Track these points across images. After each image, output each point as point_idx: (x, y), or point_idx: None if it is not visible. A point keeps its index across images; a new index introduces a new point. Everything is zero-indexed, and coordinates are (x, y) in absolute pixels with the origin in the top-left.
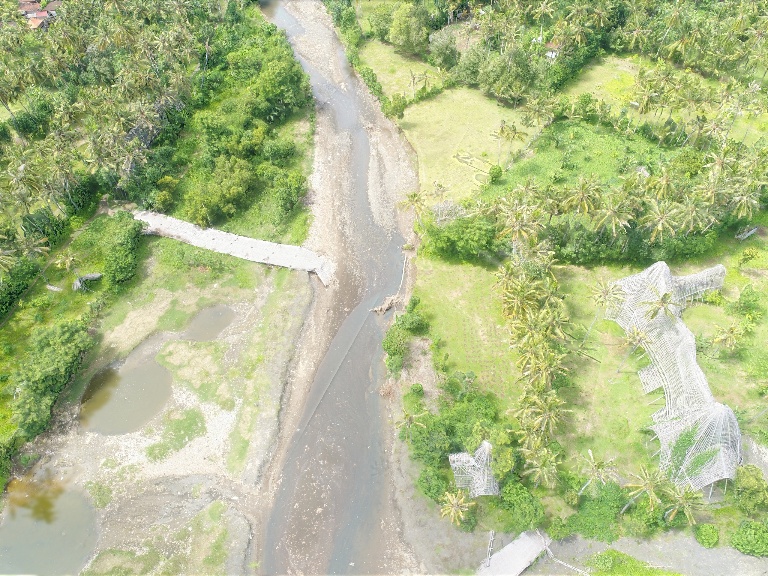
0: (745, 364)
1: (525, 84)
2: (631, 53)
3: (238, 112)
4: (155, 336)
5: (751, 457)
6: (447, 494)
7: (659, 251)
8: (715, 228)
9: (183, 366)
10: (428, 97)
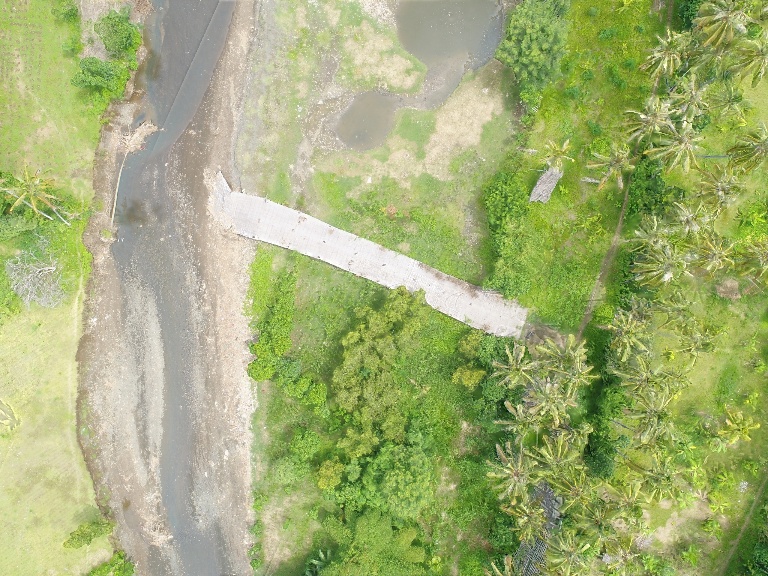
0: None
1: None
2: None
3: (374, 551)
4: (436, 105)
5: None
6: None
7: None
8: None
9: (388, 52)
10: None
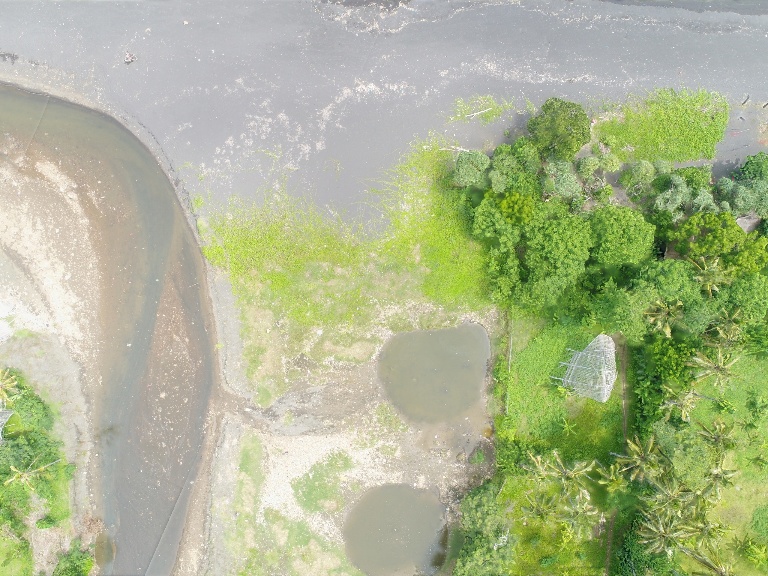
0: None
1: None
2: None
3: None
4: None
5: None
6: (7, 398)
7: None
8: None
9: (336, 570)
10: None
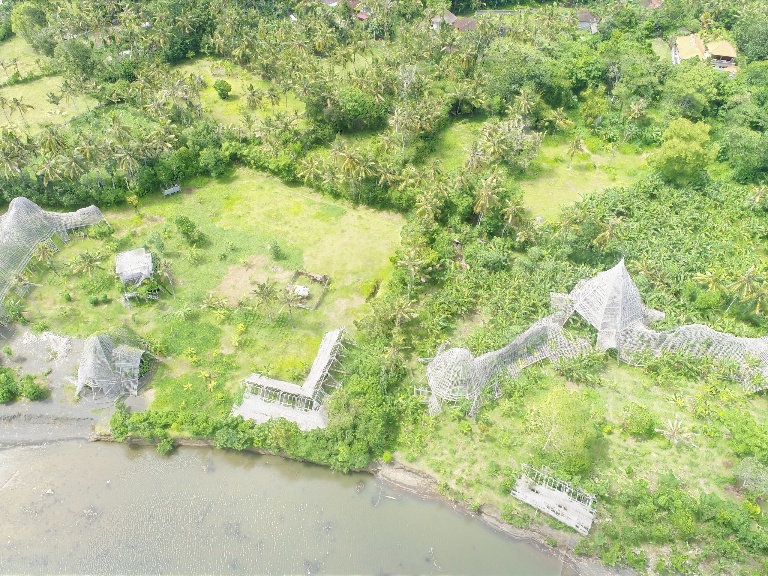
0: (79, 280)
1: (87, 73)
2: (223, 57)
3: None
4: None
5: (16, 340)
6: None
7: (64, 196)
8: (139, 184)
9: None
10: (25, 82)
